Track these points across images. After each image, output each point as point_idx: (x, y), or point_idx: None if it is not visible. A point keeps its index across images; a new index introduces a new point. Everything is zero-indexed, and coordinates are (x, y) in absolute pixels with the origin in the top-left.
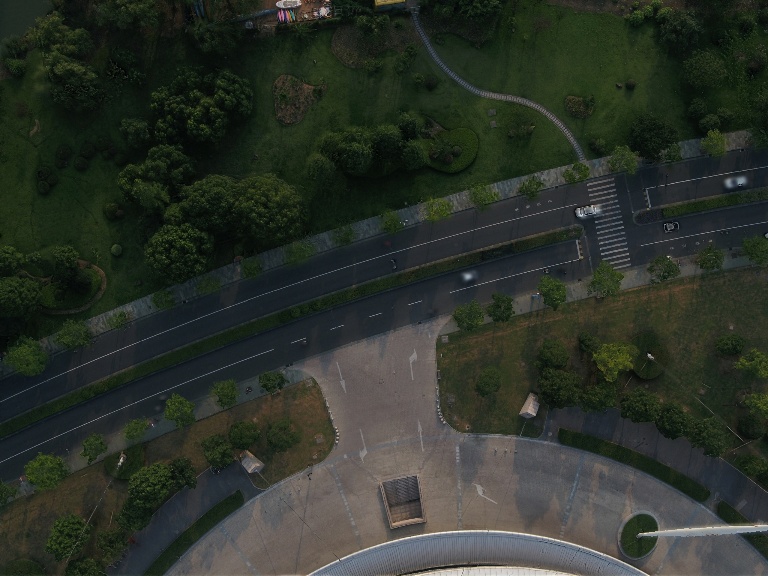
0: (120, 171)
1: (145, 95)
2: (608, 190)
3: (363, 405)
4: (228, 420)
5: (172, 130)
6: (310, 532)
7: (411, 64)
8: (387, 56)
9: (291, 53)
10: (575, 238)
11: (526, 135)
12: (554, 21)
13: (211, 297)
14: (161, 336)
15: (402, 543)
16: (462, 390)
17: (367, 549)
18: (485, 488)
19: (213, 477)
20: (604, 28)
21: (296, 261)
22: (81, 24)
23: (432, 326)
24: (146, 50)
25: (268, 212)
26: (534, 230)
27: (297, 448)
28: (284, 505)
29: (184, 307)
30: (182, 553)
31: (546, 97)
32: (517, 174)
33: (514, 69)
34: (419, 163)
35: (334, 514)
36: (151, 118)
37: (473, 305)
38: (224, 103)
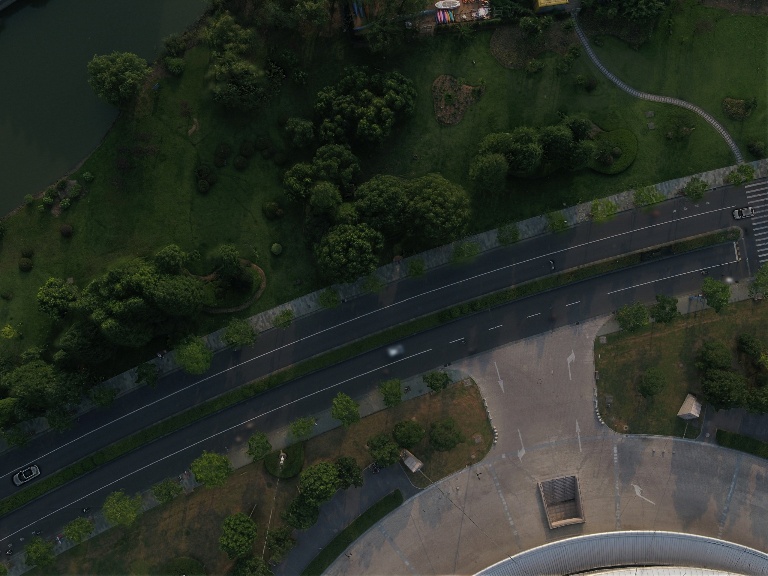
0: (280, 170)
1: (304, 94)
2: (766, 192)
3: (521, 405)
4: (387, 419)
5: (341, 130)
6: (469, 531)
7: (572, 65)
8: (546, 57)
9: (450, 53)
10: (733, 240)
11: (684, 137)
12: (711, 23)
13: (370, 296)
14: (320, 335)
15: (569, 543)
16: (620, 391)
17: (534, 549)
18: (643, 488)
19: (372, 476)
20: (761, 31)
21: (455, 261)
22: (243, 23)
23: (590, 327)
24: (304, 50)
25: (445, 212)
26: (692, 232)
27: (455, 448)
28: (442, 504)
29: (343, 306)
30: (341, 552)
31: (704, 99)
32: (675, 176)
33: (672, 71)
34: (585, 164)
35: (492, 514)
36: (313, 117)
37: (641, 306)
38: (394, 103)
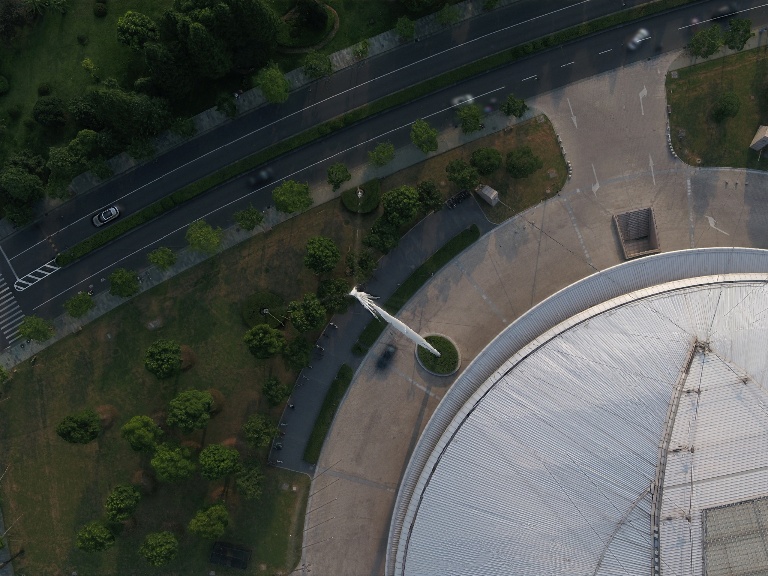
0: None
1: None
2: None
3: (594, 140)
4: (461, 156)
5: None
6: (545, 265)
7: None
8: None
9: None
10: None
11: None
12: None
13: (443, 35)
14: (394, 74)
15: (649, 260)
16: (692, 124)
17: (614, 266)
18: (717, 220)
19: (448, 212)
20: None
21: None
22: None
23: (661, 62)
24: None
25: None
26: None
27: (530, 183)
28: (518, 239)
29: (416, 45)
30: (419, 287)
31: None
32: None
33: None
34: None
35: (568, 247)
36: None
37: None
38: None
